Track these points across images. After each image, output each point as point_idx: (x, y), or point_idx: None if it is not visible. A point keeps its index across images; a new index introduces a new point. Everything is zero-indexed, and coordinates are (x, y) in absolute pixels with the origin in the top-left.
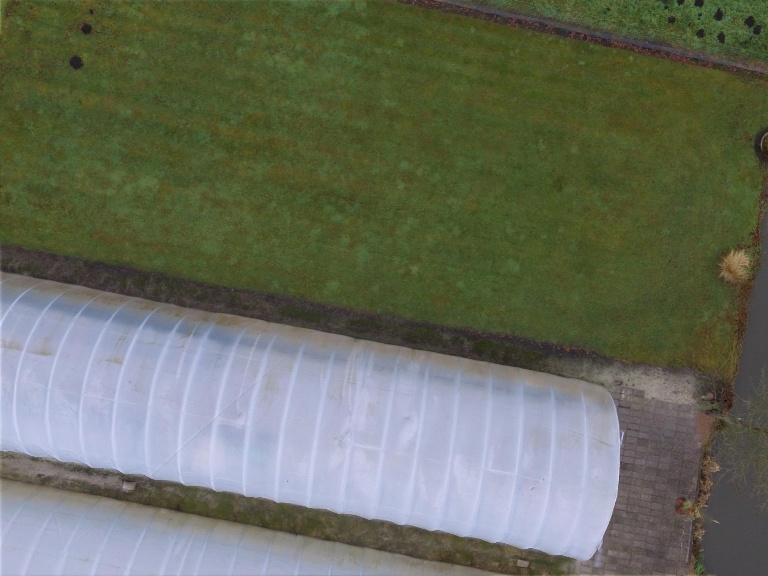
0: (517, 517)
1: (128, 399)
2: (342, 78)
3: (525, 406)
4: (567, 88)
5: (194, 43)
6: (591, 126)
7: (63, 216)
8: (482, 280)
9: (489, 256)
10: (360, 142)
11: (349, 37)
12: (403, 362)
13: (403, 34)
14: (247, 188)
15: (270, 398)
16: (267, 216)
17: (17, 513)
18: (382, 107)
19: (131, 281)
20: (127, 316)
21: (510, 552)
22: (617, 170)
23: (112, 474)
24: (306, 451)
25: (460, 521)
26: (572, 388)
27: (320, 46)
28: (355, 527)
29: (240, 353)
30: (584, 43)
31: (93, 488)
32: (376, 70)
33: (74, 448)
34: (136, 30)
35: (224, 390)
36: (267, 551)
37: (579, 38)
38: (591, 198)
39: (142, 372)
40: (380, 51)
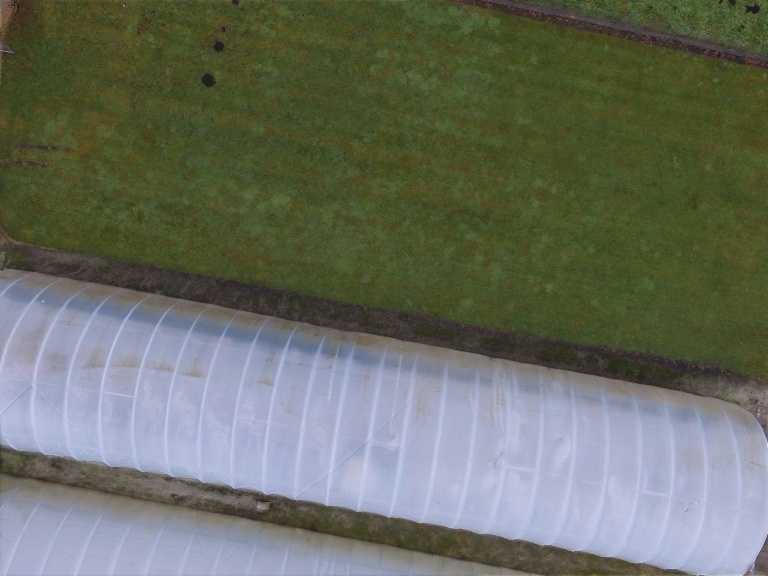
0: (670, 539)
1: (281, 421)
2: (476, 96)
3: (673, 426)
4: (701, 106)
5: (327, 61)
6: (725, 144)
7: (196, 234)
8: (617, 298)
9: (624, 274)
10: (494, 160)
11: (483, 55)
12: (546, 382)
13: (537, 52)
14: (381, 206)
15: (422, 419)
16: (401, 234)
17: (160, 535)
18: (516, 125)
19: (264, 300)
20: (270, 336)
21: (646, 571)
22: (751, 188)
23: (246, 494)
24: (460, 473)
25: (610, 542)
26: (712, 407)
27: (453, 64)
28: (491, 547)
29: (387, 374)
30: (718, 60)
31: (227, 508)
32: (510, 88)
33: (222, 470)
34: (268, 48)
35: (377, 412)
36: (409, 572)
37: (713, 55)
38: (726, 216)
39: (294, 394)
40: (514, 69)
